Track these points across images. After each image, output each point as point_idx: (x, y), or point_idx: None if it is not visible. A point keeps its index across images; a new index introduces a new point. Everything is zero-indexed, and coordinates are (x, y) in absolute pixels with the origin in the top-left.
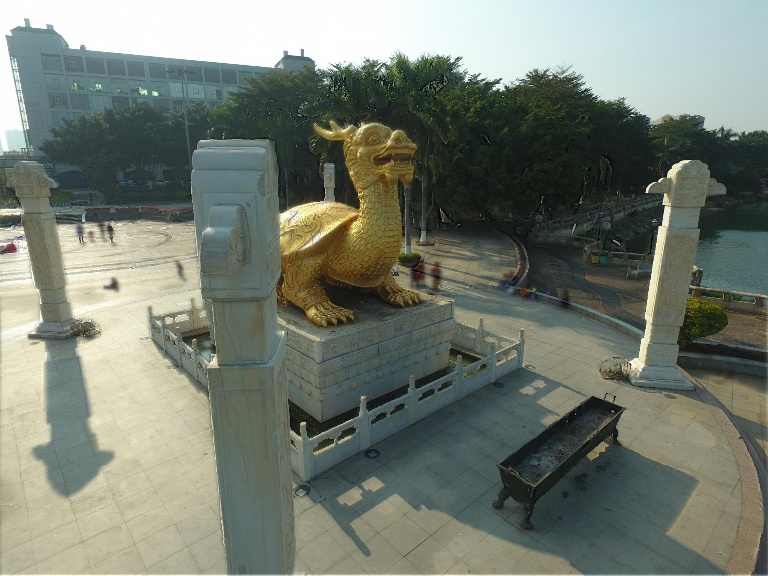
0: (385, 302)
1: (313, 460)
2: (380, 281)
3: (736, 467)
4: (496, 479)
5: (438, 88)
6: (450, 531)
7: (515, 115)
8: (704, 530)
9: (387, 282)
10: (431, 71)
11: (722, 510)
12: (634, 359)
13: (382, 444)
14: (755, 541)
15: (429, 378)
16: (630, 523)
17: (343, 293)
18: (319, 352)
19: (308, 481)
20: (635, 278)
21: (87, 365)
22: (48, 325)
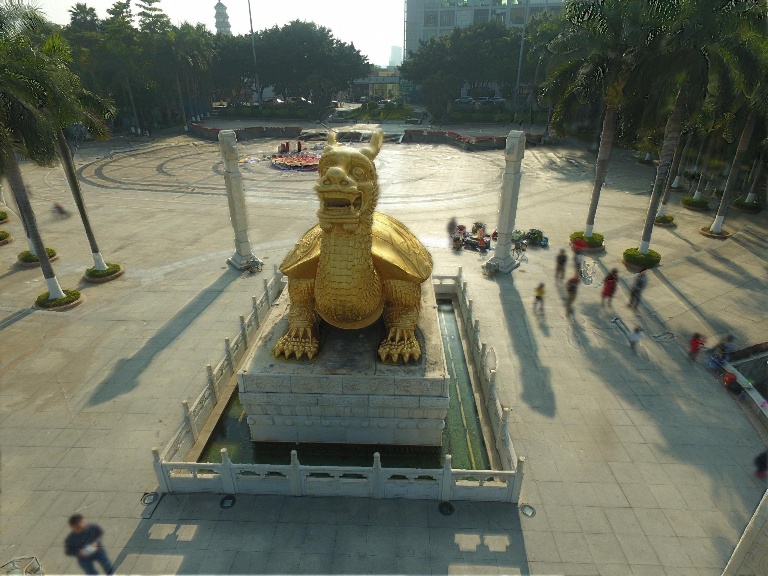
0: (379, 346)
1: (169, 479)
2: (365, 324)
3: None
4: None
5: (747, 6)
6: None
7: None
8: None
9: (395, 323)
10: None
11: None
12: None
13: (247, 498)
14: None
15: (396, 449)
16: None
17: None
18: (240, 383)
19: (165, 493)
20: None
21: (217, 301)
22: (236, 256)
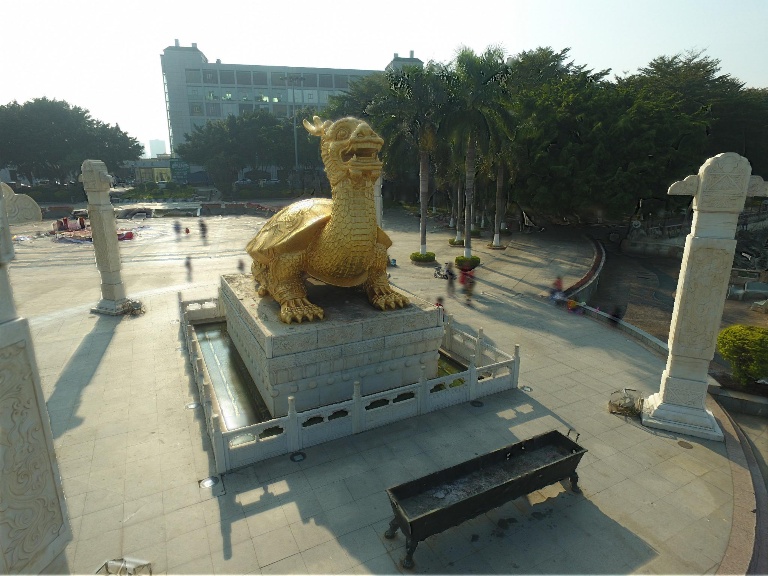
0: (369, 303)
1: (228, 454)
2: (361, 281)
3: (723, 547)
4: None
5: (502, 81)
6: (322, 552)
7: (617, 108)
8: None
9: (376, 283)
10: (528, 65)
11: None
12: (654, 394)
13: (314, 449)
14: None
15: None
16: None
17: (339, 291)
18: (268, 347)
19: (222, 474)
20: (738, 299)
21: (116, 340)
22: (106, 302)
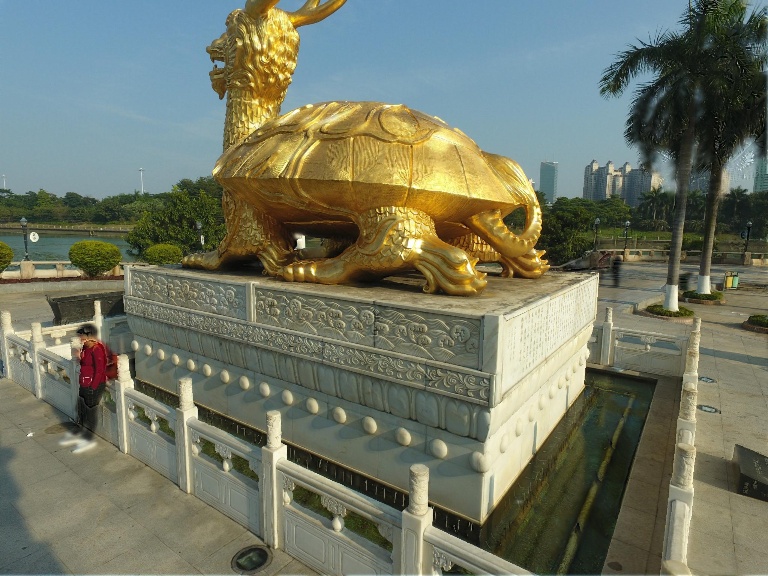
0: None
1: None
2: None
3: None
4: None
5: None
6: None
7: None
8: None
9: None
10: None
11: None
12: None
13: None
14: None
15: None
16: None
17: None
18: None
19: None
20: None
21: None
22: None
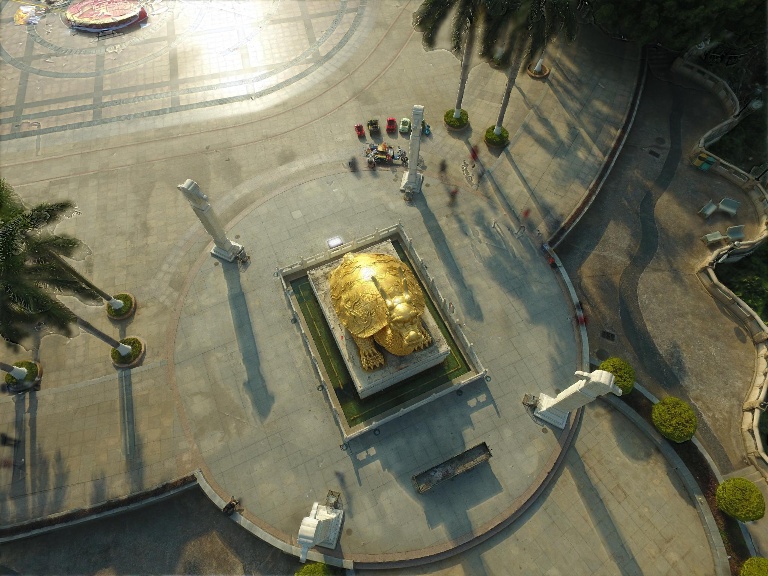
0: None
1: None
2: None
3: (526, 489)
4: (421, 464)
5: None
6: (391, 485)
7: None
8: (482, 514)
9: None
10: None
11: (497, 508)
12: (547, 399)
13: (383, 427)
14: (496, 524)
15: (426, 373)
16: (457, 502)
17: None
18: None
19: (348, 442)
20: (704, 217)
21: (250, 306)
22: (220, 250)
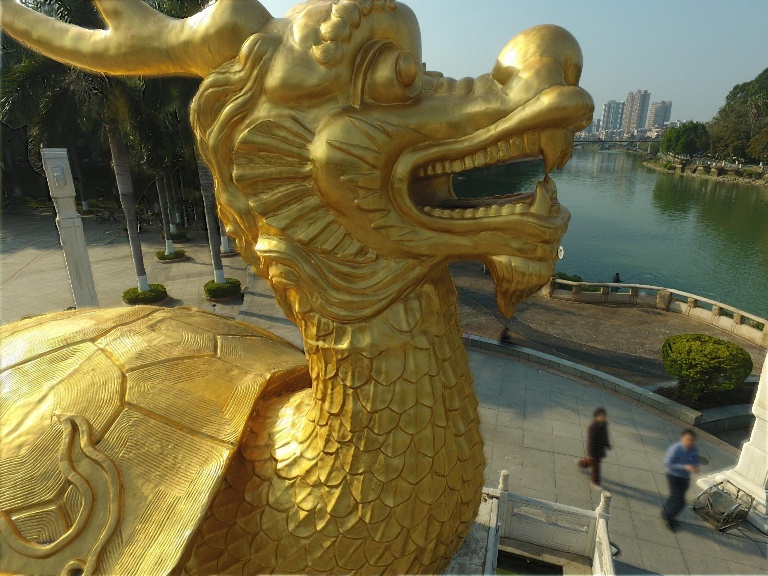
0: None
1: None
2: None
3: None
4: None
5: None
6: None
7: None
8: None
9: None
10: None
11: None
12: (728, 474)
13: None
14: None
15: None
16: None
17: None
18: None
19: None
20: None
21: None
22: None
